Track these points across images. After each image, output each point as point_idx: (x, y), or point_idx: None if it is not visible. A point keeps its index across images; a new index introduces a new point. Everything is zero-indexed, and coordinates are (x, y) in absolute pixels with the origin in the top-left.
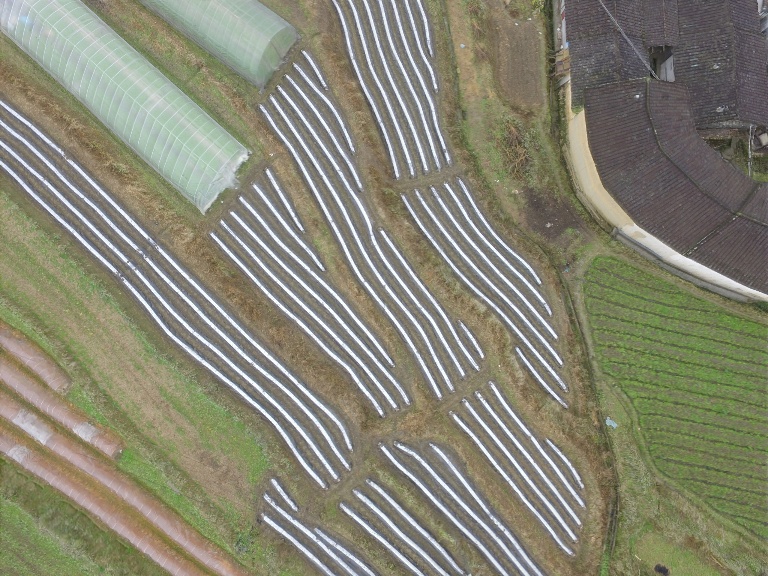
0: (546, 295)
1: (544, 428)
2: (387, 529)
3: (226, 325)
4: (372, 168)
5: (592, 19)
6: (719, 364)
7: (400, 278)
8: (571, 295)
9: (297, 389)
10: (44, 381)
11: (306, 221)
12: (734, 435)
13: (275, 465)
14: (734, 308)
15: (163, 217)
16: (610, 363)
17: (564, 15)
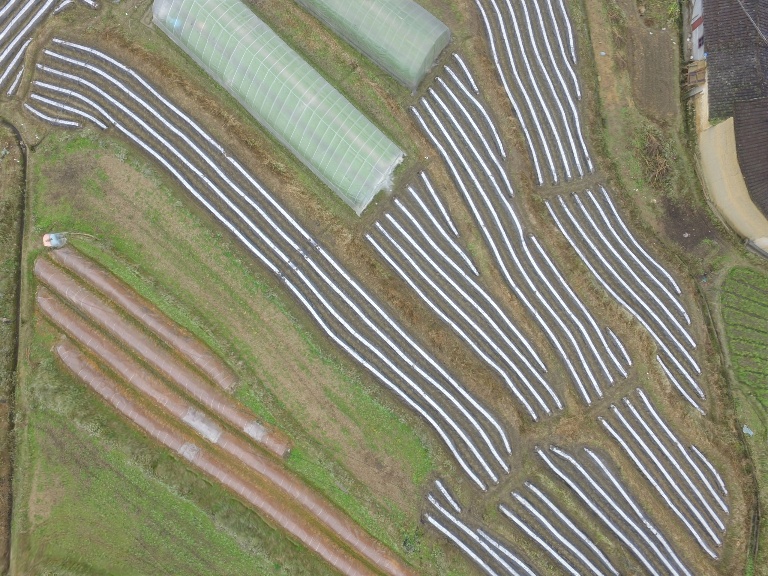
0: (685, 304)
1: (691, 435)
2: (545, 531)
3: (386, 327)
4: (523, 174)
5: (733, 32)
6: None
7: (550, 284)
8: (708, 305)
9: (457, 392)
10: (211, 379)
11: (461, 225)
12: None
13: (439, 467)
14: None
15: (322, 218)
16: (746, 372)
17: (696, 26)
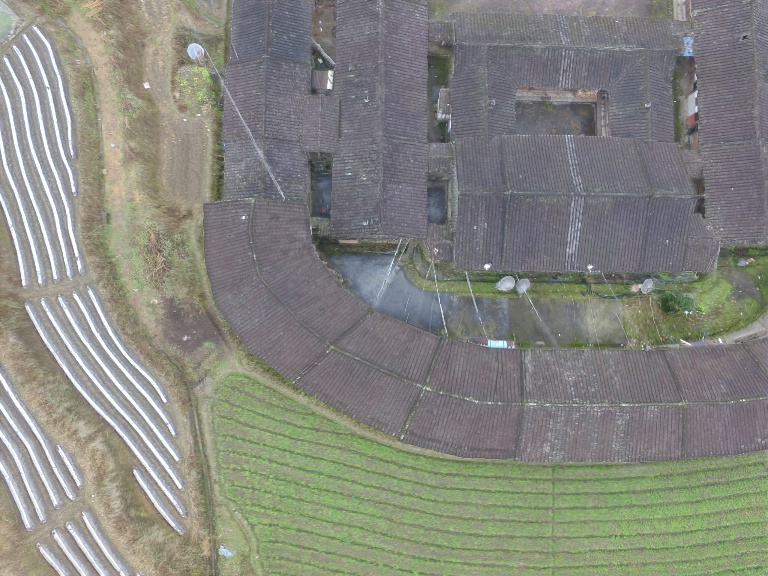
0: (172, 414)
1: (133, 563)
2: None
3: None
4: None
5: None
6: (346, 490)
7: None
8: (199, 414)
9: None
10: None
11: None
12: (356, 565)
13: None
14: (366, 431)
15: None
16: (232, 487)
17: None
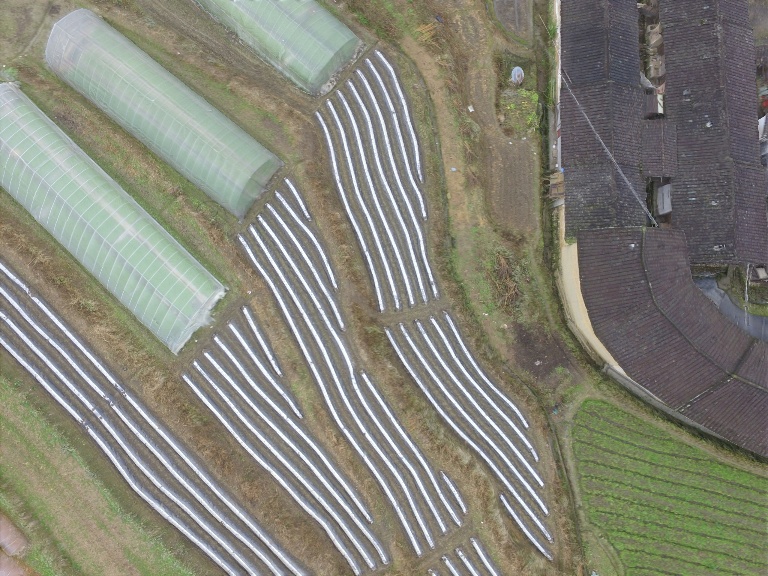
0: (533, 439)
1: None
2: None
3: (196, 479)
4: (355, 307)
5: (588, 147)
6: (709, 516)
7: (381, 425)
8: (559, 439)
9: (269, 550)
10: None
11: (284, 365)
12: None
13: None
14: (726, 457)
15: (132, 361)
16: (597, 513)
17: (560, 134)
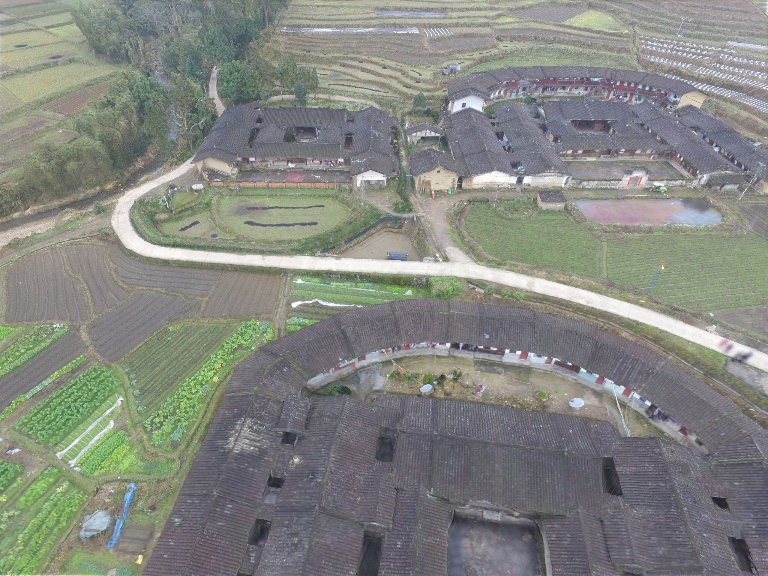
0: None
1: None
2: None
3: None
4: (764, 90)
5: None
6: None
7: None
8: None
9: None
10: None
11: None
12: None
13: None
14: None
15: None
16: None
17: None
